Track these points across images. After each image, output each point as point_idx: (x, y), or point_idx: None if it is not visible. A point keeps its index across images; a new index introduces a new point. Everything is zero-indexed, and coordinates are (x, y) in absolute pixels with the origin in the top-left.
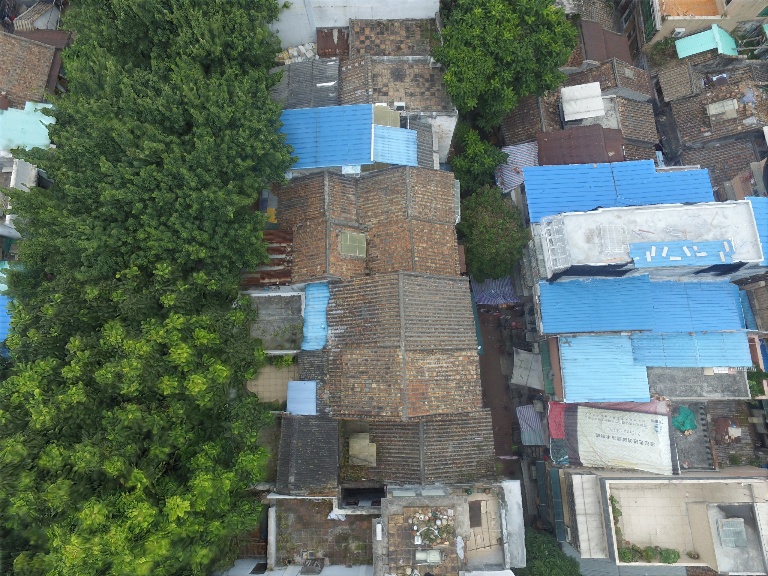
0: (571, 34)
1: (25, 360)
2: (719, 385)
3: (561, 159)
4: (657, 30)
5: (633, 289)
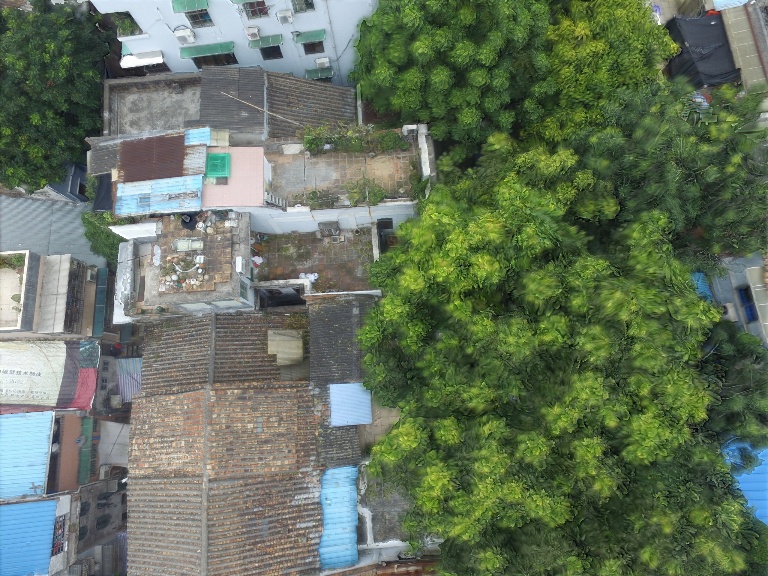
0: None
1: (703, 447)
2: None
3: None
4: None
5: None
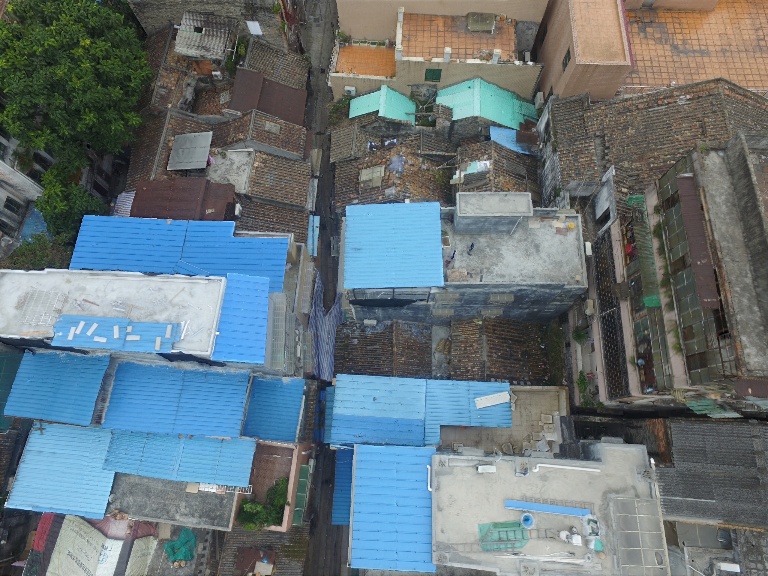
0: (116, 72)
1: None
2: (199, 507)
3: (152, 211)
4: (329, 86)
5: (90, 372)
